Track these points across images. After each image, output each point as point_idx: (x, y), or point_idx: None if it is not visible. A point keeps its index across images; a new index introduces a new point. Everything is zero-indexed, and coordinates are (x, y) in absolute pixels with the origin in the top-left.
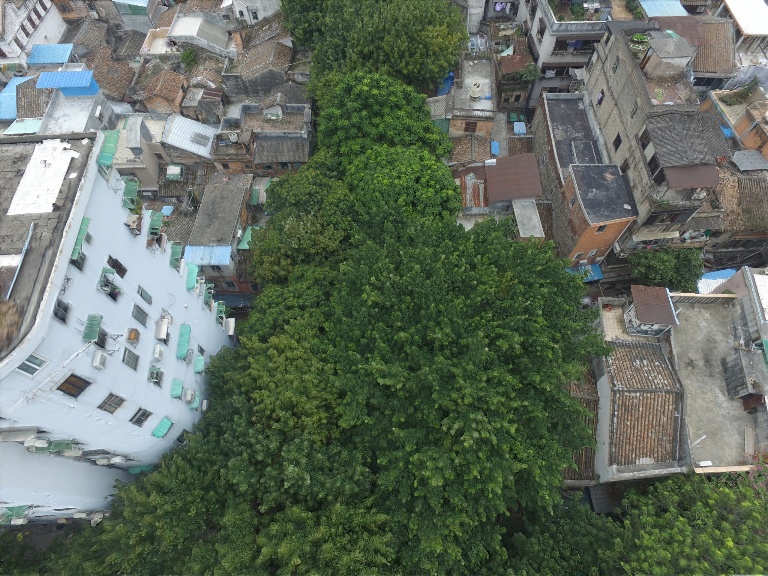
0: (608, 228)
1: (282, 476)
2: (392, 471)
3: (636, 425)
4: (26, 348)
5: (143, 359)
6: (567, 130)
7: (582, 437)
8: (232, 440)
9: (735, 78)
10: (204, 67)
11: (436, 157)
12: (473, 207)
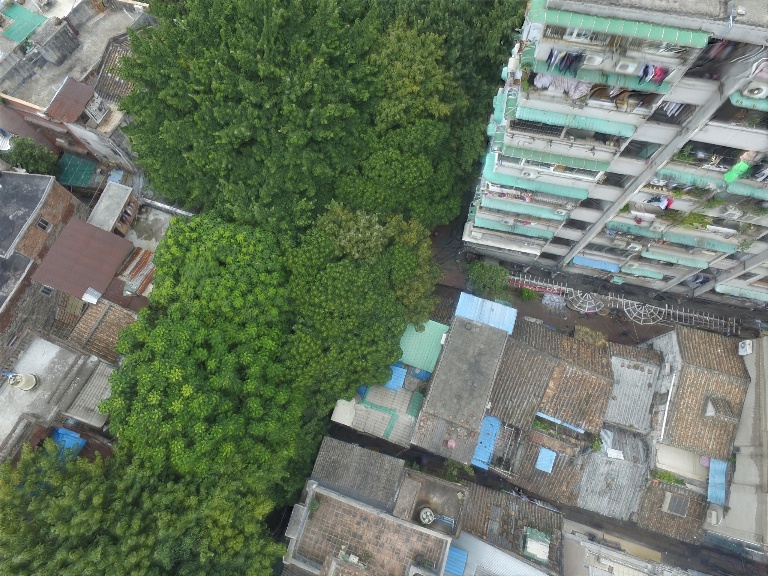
0: None
1: None
2: (352, 4)
3: None
4: None
5: None
6: None
7: None
8: None
9: None
10: None
11: (154, 311)
12: None
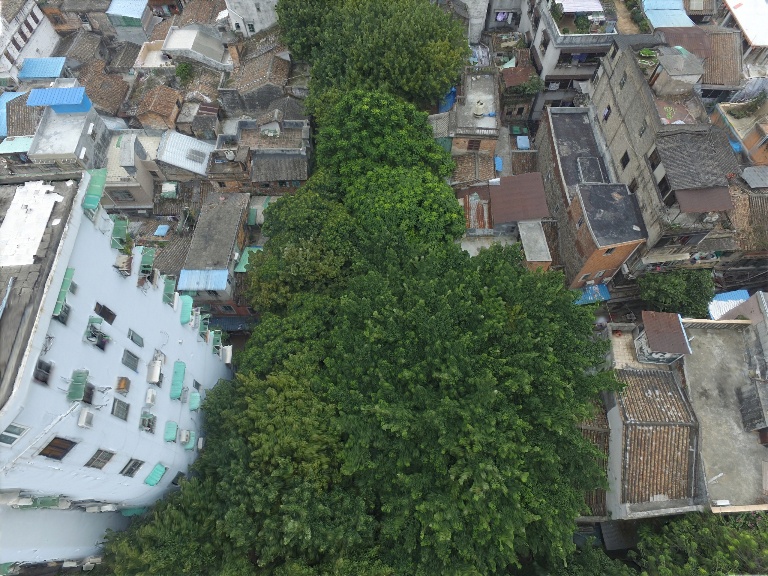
0: (617, 250)
1: (281, 529)
2: (397, 519)
3: (649, 460)
4: (2, 421)
5: (134, 407)
6: (572, 146)
7: (595, 478)
8: (229, 488)
9: (743, 90)
10: (200, 81)
11: (439, 177)
12: (477, 228)
